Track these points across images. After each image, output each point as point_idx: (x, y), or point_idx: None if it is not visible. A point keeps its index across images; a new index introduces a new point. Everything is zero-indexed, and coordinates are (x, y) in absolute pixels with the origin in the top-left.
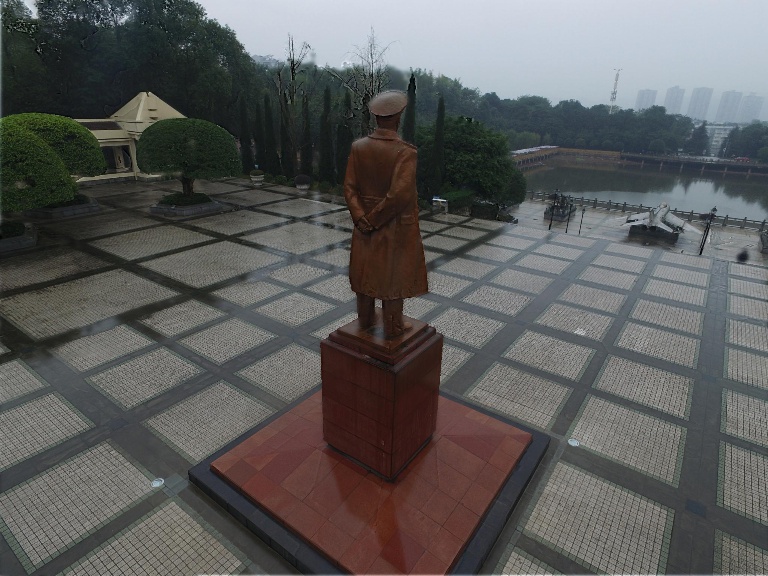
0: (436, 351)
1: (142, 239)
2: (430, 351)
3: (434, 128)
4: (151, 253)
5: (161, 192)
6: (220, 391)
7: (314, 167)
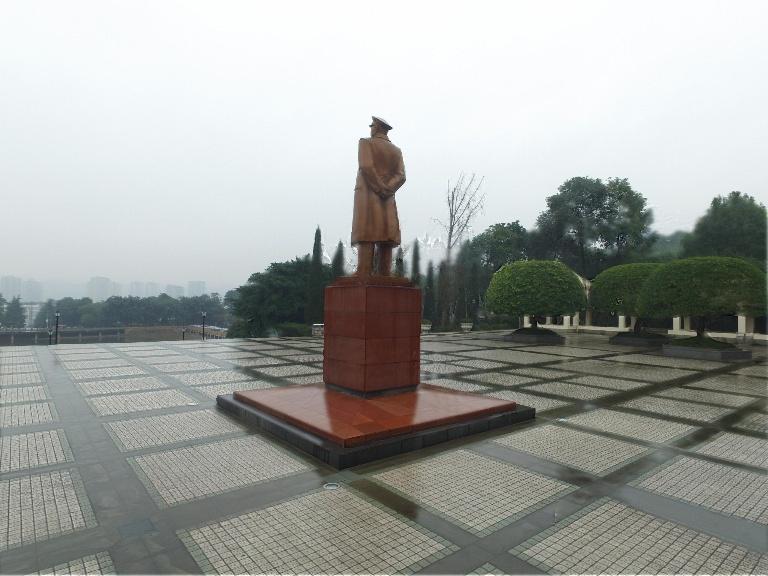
0: None
1: None
2: None
3: None
4: None
5: None
6: (160, 458)
7: None
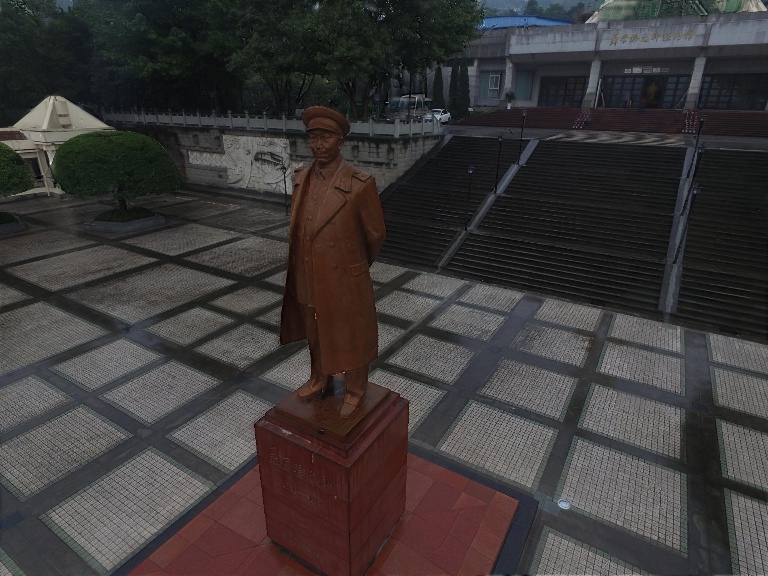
0: None
1: None
2: None
3: None
4: None
5: None
6: None
7: None
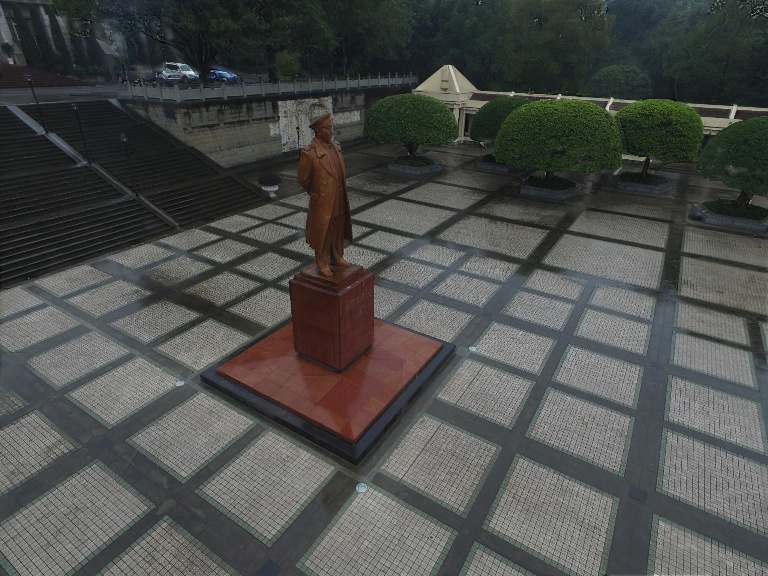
0: (330, 303)
1: (617, 223)
2: (323, 297)
3: None
4: (591, 232)
5: (761, 198)
6: (400, 298)
7: None
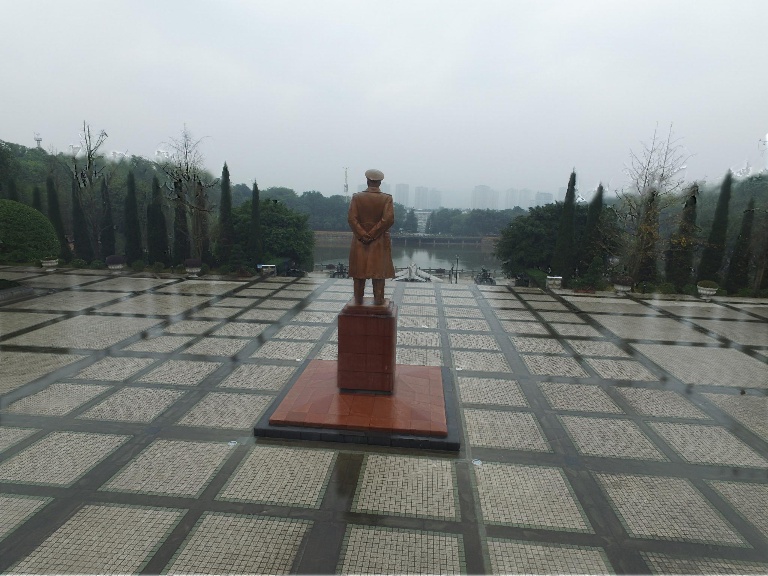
0: None
1: None
2: None
3: (244, 208)
4: None
5: None
6: (217, 397)
7: (116, 249)
